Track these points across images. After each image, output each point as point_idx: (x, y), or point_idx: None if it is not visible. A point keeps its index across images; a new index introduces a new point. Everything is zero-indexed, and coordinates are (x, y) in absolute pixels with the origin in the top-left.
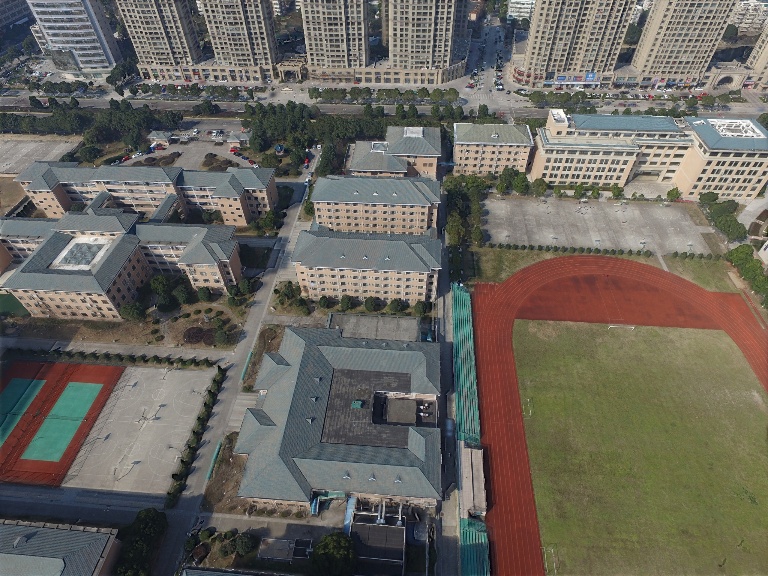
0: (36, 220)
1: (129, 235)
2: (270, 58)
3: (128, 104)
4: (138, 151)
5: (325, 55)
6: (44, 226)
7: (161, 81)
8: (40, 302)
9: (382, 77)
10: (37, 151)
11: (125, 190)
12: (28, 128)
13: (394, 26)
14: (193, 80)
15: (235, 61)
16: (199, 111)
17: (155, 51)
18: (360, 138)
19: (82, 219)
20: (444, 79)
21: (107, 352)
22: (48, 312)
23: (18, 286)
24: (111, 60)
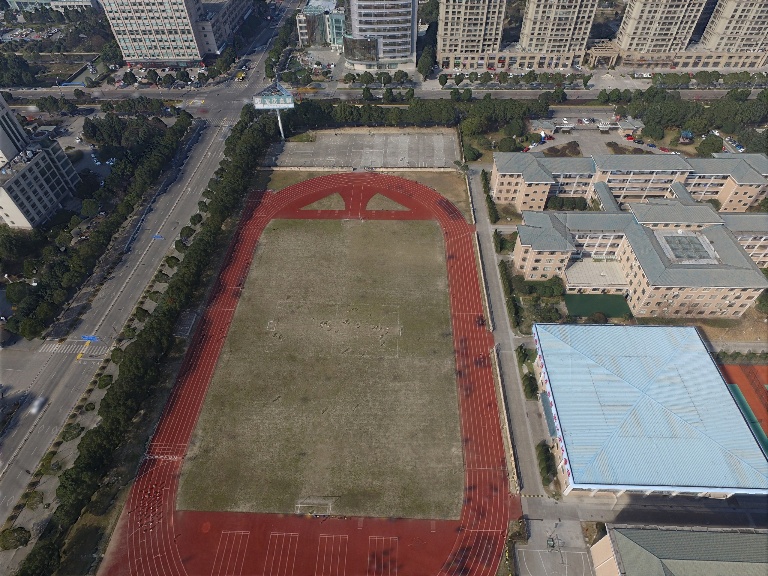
0: (600, 213)
1: (722, 226)
2: (585, 43)
3: (471, 93)
4: (532, 141)
5: (650, 39)
6: (615, 219)
7: (462, 70)
8: (670, 300)
9: (702, 61)
10: (418, 144)
11: (620, 180)
12: (396, 120)
13: (736, 7)
14: (496, 68)
15: (548, 47)
16: (547, 99)
17: (466, 38)
18: (749, 123)
19: (670, 210)
20: (765, 62)
21: (764, 351)
22: (660, 311)
23: (672, 283)
24: (413, 49)
